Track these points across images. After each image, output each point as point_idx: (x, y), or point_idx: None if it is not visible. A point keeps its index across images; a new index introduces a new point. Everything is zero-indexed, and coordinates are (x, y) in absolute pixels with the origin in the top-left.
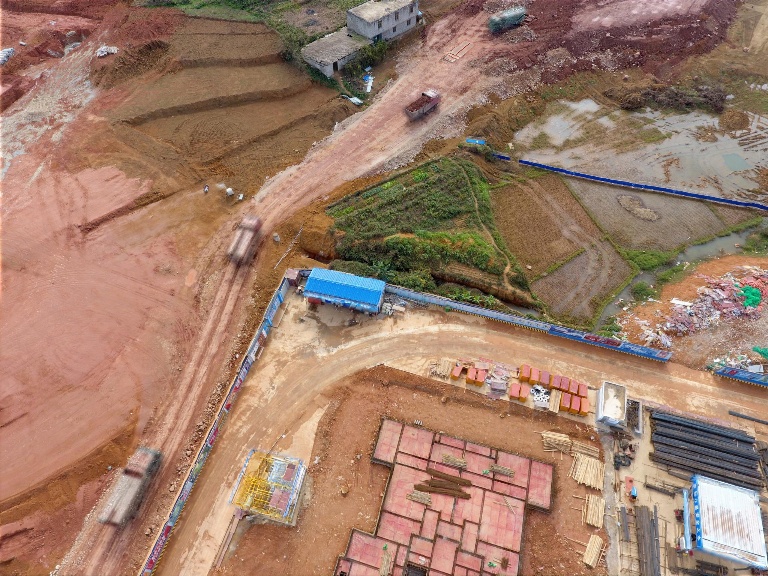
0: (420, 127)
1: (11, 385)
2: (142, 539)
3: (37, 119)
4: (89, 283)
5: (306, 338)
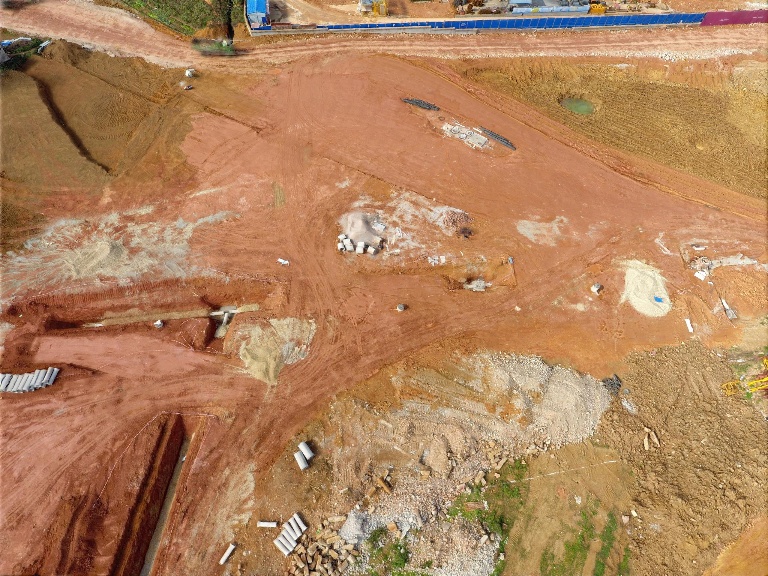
0: (82, 7)
1: (386, 102)
2: (416, 38)
3: (118, 243)
4: (303, 106)
5: (293, 20)
